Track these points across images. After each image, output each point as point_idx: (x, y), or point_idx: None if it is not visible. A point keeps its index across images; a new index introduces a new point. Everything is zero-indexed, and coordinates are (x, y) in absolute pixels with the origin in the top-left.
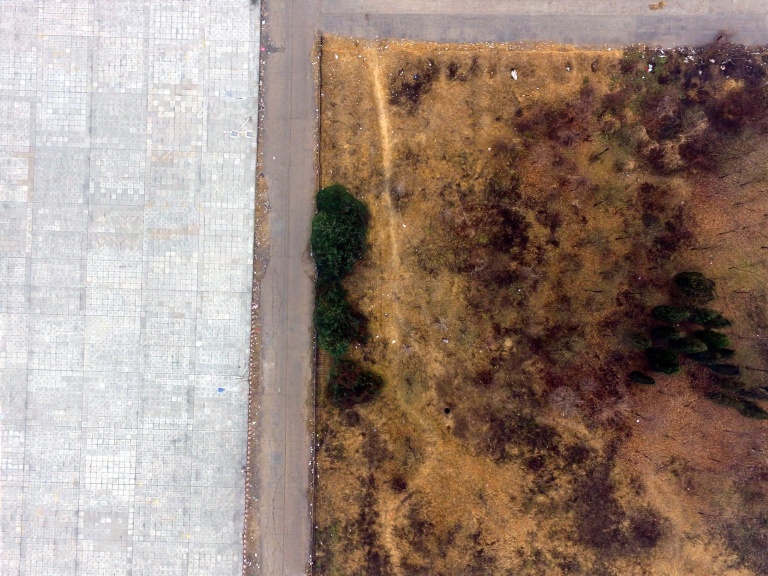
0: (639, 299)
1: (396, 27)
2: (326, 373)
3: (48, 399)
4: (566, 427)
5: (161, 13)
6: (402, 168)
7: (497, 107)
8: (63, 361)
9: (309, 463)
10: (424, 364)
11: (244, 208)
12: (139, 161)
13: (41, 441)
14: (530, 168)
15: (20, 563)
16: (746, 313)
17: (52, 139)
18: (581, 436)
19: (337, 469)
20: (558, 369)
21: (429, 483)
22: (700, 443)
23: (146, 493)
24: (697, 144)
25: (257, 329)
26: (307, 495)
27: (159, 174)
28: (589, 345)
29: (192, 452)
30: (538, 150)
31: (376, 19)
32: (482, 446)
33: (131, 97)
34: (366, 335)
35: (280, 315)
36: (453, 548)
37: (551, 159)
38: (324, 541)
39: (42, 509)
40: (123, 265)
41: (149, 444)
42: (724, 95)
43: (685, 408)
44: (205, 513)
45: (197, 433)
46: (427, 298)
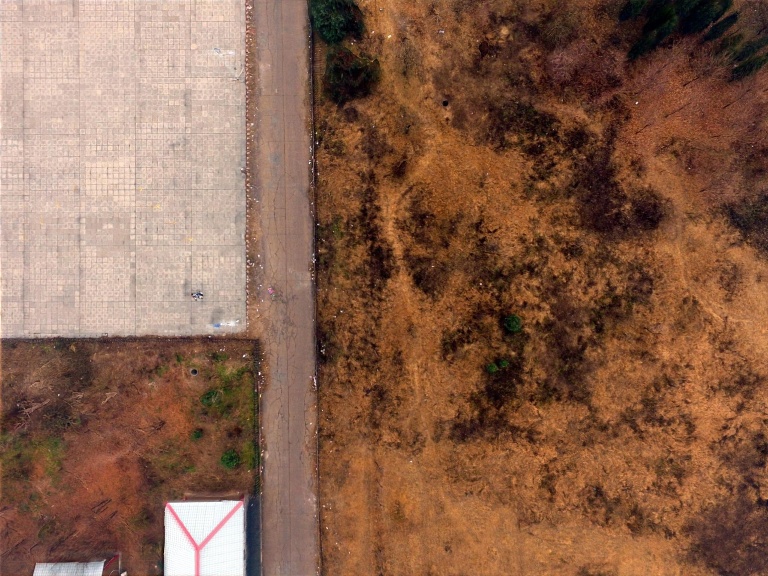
0: None
1: None
2: (323, 70)
3: (45, 107)
4: (565, 112)
5: None
6: None
7: None
8: (58, 69)
9: (309, 162)
10: (421, 58)
11: None
12: None
13: (40, 149)
14: None
15: (24, 271)
16: None
17: None
18: (580, 120)
19: (337, 166)
20: (555, 55)
21: (429, 174)
22: (700, 122)
23: (147, 198)
24: None
25: (252, 30)
26: (308, 194)
27: None
28: (586, 30)
29: (191, 155)
30: None
31: None
32: (481, 136)
33: None
34: (361, 23)
35: (274, 16)
36: (455, 237)
37: None
38: (326, 238)
39: (44, 217)
40: None
41: (148, 149)
42: None
43: (684, 88)
44: (206, 216)
45: (195, 136)
46: None
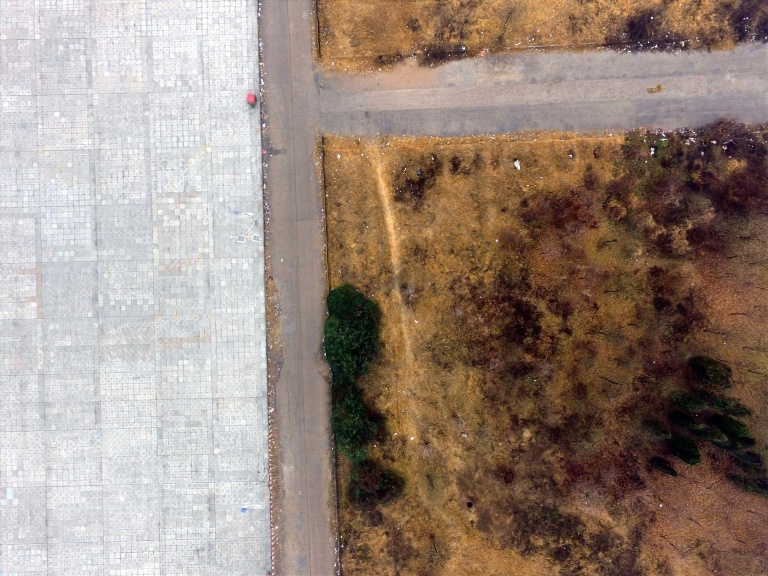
0: (655, 383)
1: (397, 123)
2: (346, 474)
3: (68, 515)
4: (589, 515)
5: (161, 122)
6: (411, 264)
7: (502, 198)
8: (81, 476)
9: (334, 565)
10: (444, 459)
11: (255, 312)
12: (147, 271)
13: (63, 558)
14: (538, 258)
15: None
16: (762, 392)
17: (58, 254)
18: (605, 524)
19: (363, 570)
20: (578, 457)
21: None
22: (724, 524)
23: None
24: (704, 226)
25: (274, 433)
26: None
27: (168, 283)
28: (608, 432)
29: (216, 561)
30: (545, 239)
31: (376, 116)
32: (507, 539)
33: (135, 208)
34: (384, 436)
35: (297, 417)
36: None
37: (559, 248)
38: None
39: None
40: (136, 376)
41: (172, 555)
42: (727, 175)
43: (707, 490)
44: None
45: (220, 541)
46: (443, 393)
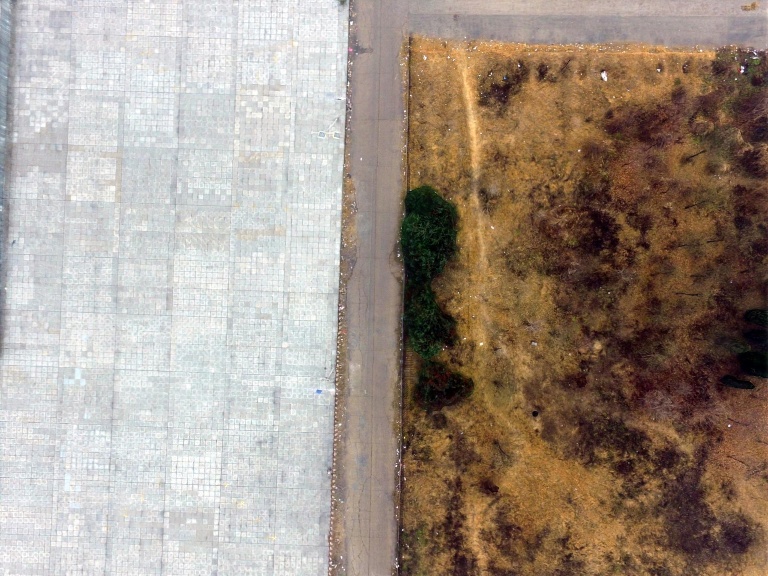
0: (731, 303)
1: (485, 28)
2: (413, 375)
3: (134, 399)
4: (656, 431)
5: (249, 14)
6: (491, 170)
7: (587, 109)
8: (149, 361)
9: (395, 465)
10: (512, 367)
11: (331, 209)
12: (226, 162)
13: (127, 441)
14: (620, 170)
15: (106, 563)
16: None
17: (140, 139)
18: (672, 440)
19: (424, 472)
20: (648, 373)
21: (517, 487)
22: None
23: (232, 494)
24: None
25: (343, 330)
26: (393, 498)
27: (246, 175)
28: (680, 349)
29: (278, 453)
30: (628, 152)
31: (465, 20)
32: (571, 450)
33: (219, 98)
34: (455, 337)
35: (366, 316)
36: (541, 552)
37: (642, 161)
38: (411, 544)
39: (128, 509)
40: (210, 265)
41: (235, 445)
42: None
43: None
44: (291, 515)
45: (283, 434)
46: (515, 300)
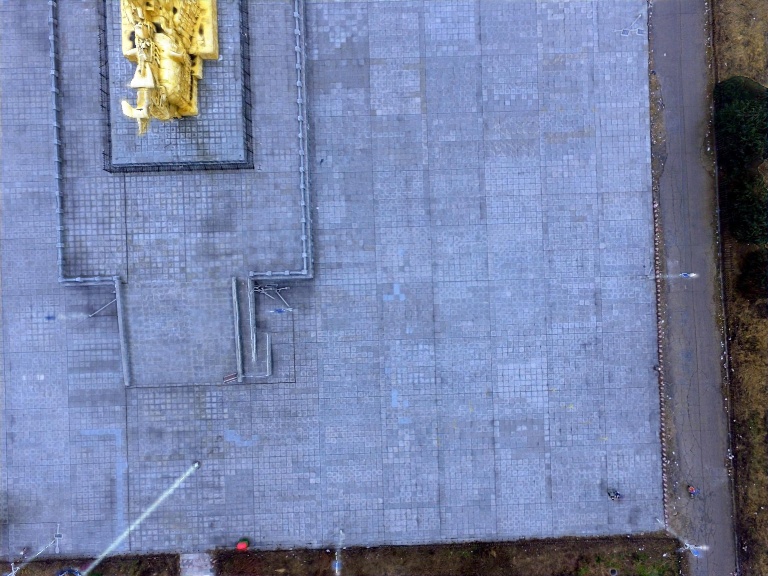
0: None
1: None
2: (734, 266)
3: (455, 311)
4: None
5: None
6: None
7: None
8: (467, 272)
9: (721, 358)
10: None
11: (639, 106)
12: (531, 66)
13: (451, 353)
14: None
15: (439, 476)
16: None
17: (442, 49)
18: None
19: (751, 361)
20: None
21: None
22: None
23: (560, 398)
24: None
25: (659, 228)
26: (721, 390)
27: (552, 77)
28: None
29: (603, 354)
30: None
31: None
32: None
33: (519, 1)
34: None
35: (681, 212)
36: None
37: None
38: (743, 434)
39: (457, 421)
40: (521, 171)
41: (559, 349)
42: None
43: None
44: (620, 414)
45: (607, 335)
46: None
